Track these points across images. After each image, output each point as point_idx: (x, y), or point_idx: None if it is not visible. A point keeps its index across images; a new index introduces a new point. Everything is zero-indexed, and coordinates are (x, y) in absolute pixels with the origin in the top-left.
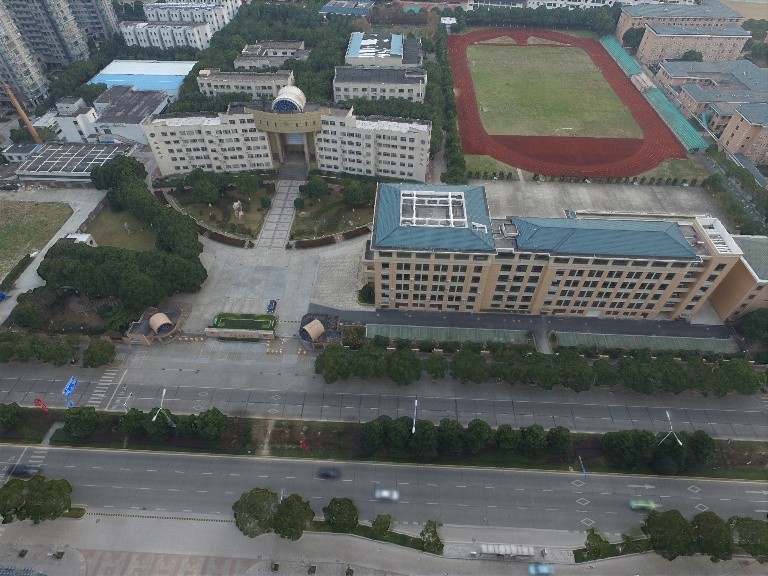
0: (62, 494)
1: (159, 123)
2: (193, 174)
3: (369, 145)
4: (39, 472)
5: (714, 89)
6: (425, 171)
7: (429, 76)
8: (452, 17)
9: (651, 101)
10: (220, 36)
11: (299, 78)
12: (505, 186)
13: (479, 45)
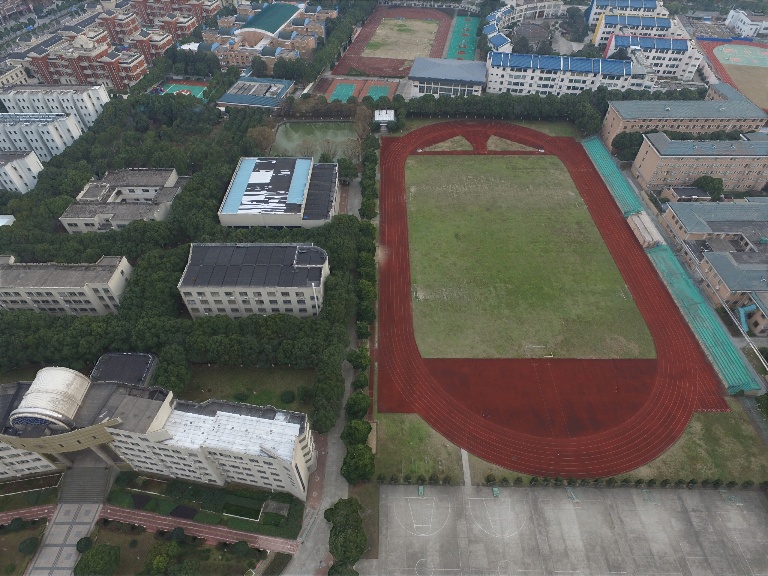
0: None
1: None
2: None
3: (199, 461)
4: None
5: (751, 261)
6: (303, 488)
7: (335, 253)
8: (389, 109)
9: (660, 271)
10: (53, 168)
11: (133, 269)
12: (439, 504)
13: (423, 155)
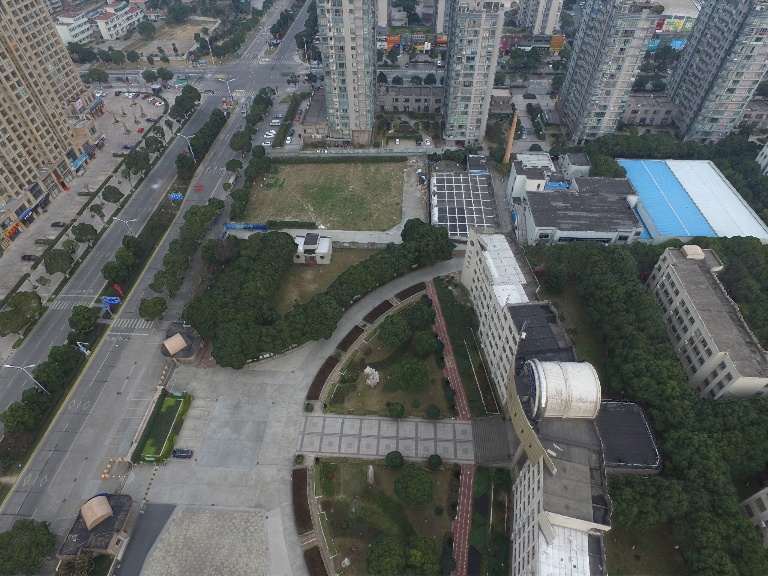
0: (3, 328)
1: (482, 240)
2: (417, 306)
3: None
4: (69, 310)
5: None
6: None
7: None
8: None
9: None
10: None
11: None
12: None
13: None
